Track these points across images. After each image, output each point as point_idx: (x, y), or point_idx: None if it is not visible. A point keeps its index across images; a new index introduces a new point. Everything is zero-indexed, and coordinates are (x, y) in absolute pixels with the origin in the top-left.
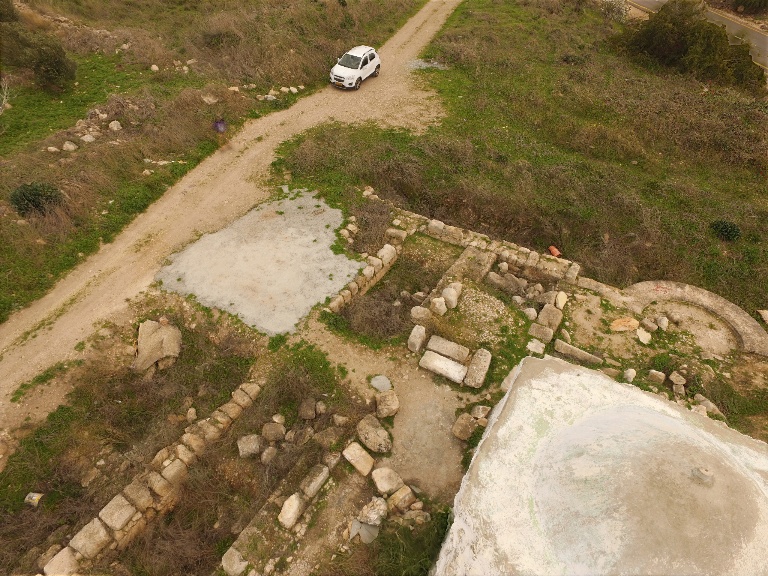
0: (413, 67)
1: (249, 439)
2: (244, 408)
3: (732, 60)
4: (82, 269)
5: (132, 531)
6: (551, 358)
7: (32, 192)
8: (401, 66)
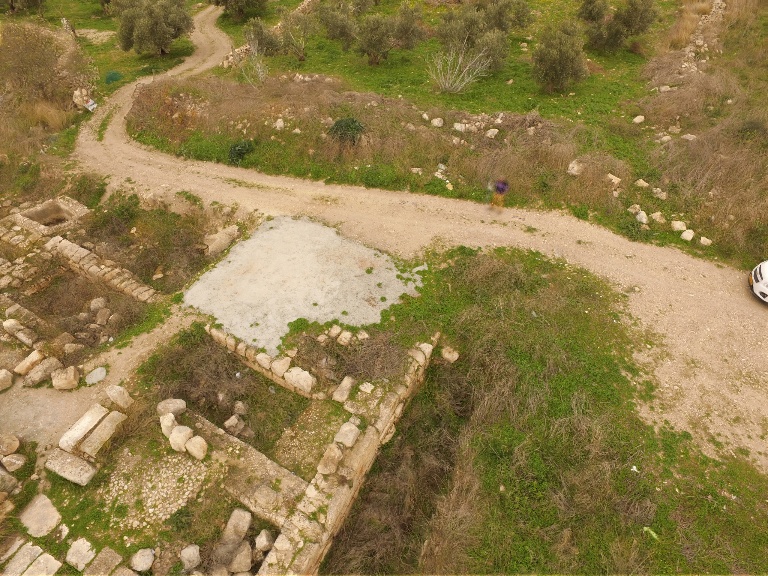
0: None
1: (99, 302)
2: (132, 296)
3: None
4: (295, 181)
5: (74, 268)
6: (50, 570)
7: (343, 124)
8: None
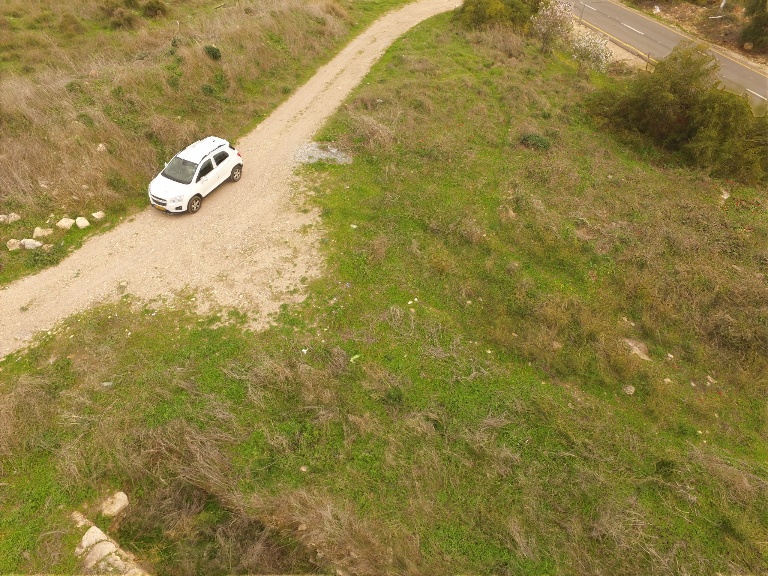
0: (299, 159)
1: None
2: None
3: (756, 140)
4: None
5: None
6: None
7: None
8: (282, 157)
